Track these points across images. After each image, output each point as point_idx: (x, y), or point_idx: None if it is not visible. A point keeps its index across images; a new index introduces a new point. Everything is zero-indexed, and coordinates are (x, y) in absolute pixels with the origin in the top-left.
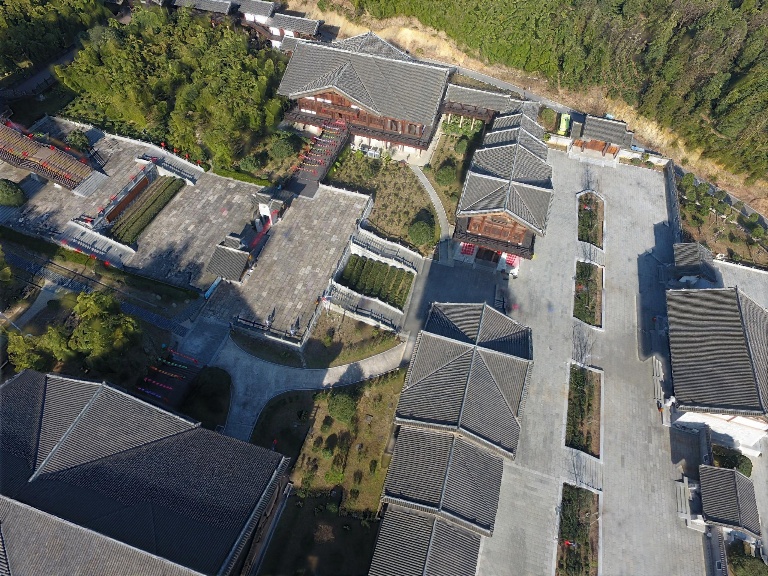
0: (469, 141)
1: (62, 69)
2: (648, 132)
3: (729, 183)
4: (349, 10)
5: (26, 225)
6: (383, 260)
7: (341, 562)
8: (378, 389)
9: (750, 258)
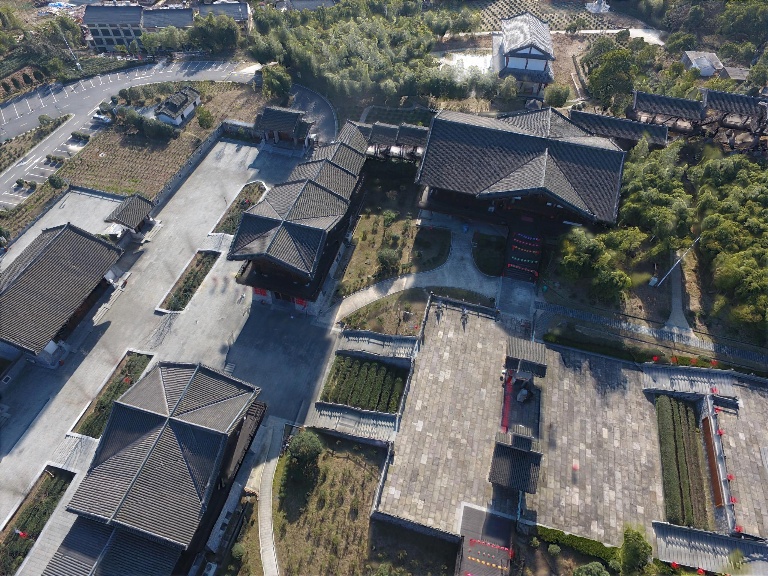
0: None
1: None
2: None
3: None
4: None
5: None
6: None
7: (381, 198)
8: None
9: None
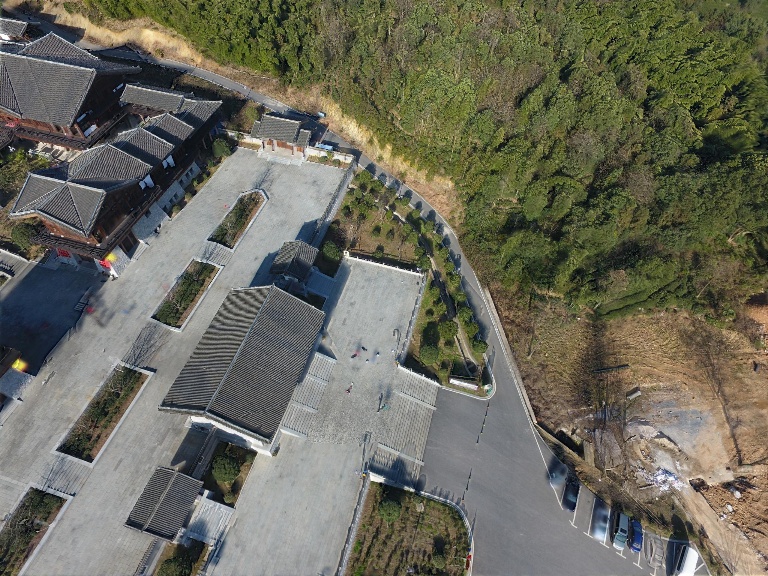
0: None
1: None
2: (352, 130)
3: (416, 179)
4: None
5: None
6: None
7: None
8: None
9: (397, 255)
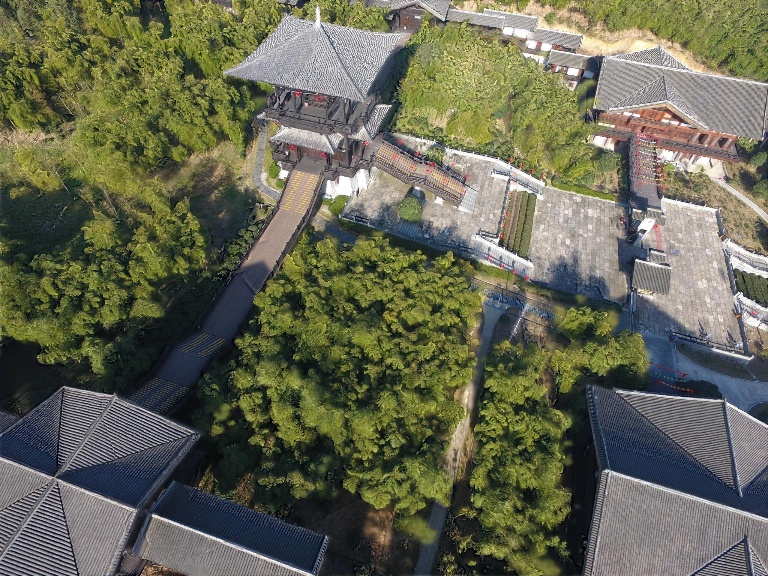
0: (748, 153)
1: (410, 86)
2: None
3: None
4: (579, 23)
5: (435, 241)
6: (758, 273)
7: None
8: None
9: None
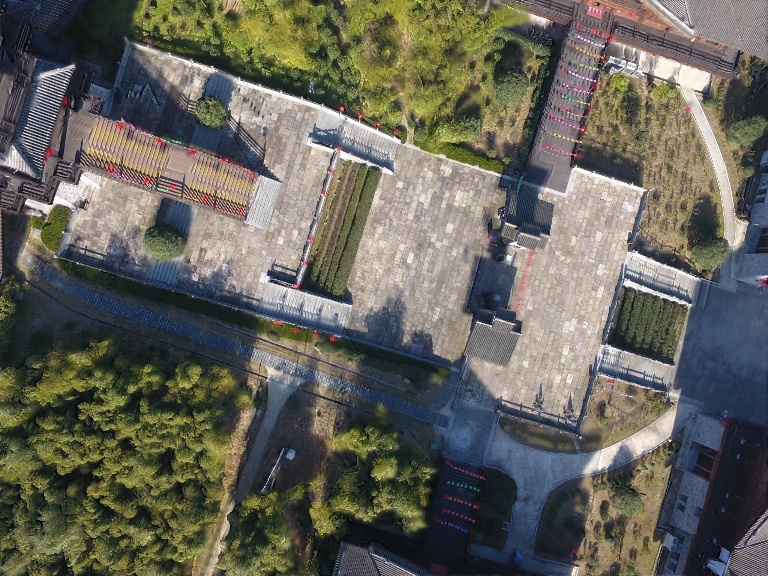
0: None
1: None
2: None
3: None
4: None
5: (207, 287)
6: (656, 294)
7: None
8: (651, 466)
9: None
